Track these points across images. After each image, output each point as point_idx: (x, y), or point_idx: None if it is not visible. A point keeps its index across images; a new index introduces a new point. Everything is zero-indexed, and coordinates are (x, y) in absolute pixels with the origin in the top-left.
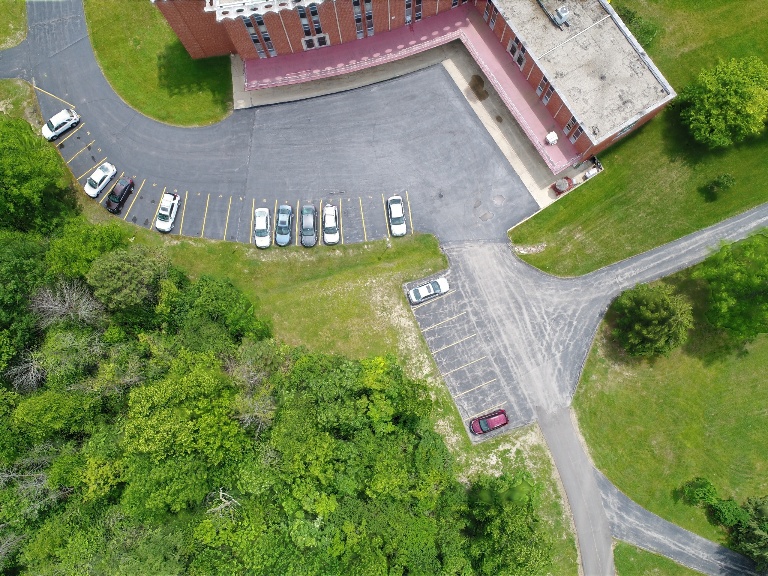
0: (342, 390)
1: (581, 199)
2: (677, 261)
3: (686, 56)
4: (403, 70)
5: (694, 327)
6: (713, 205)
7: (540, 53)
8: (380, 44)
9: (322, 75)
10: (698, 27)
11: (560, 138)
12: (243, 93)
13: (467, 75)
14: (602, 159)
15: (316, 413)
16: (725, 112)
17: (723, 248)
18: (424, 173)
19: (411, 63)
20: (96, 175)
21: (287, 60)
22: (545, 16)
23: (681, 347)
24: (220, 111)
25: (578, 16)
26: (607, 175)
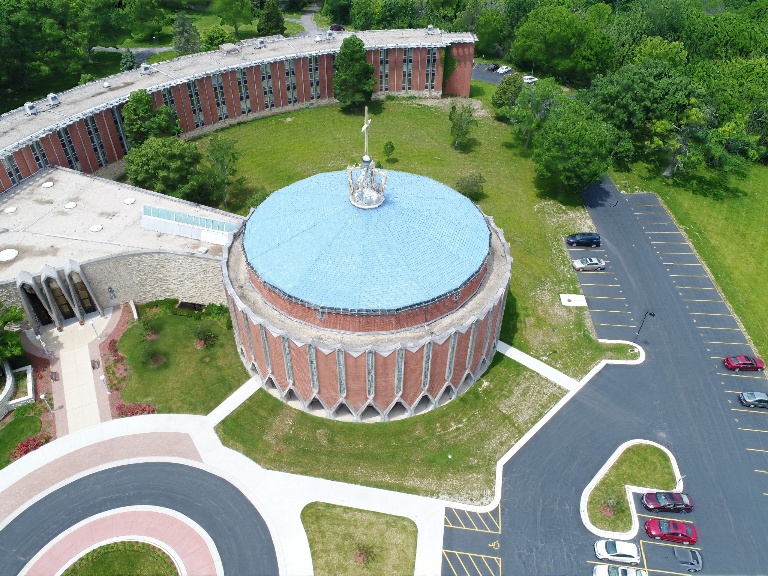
0: (390, 2)
1: None
2: None
3: None
4: None
5: None
6: None
7: None
8: None
9: None
10: None
11: None
12: None
13: None
14: None
15: (399, 2)
16: None
17: None
18: None
19: None
20: (505, 67)
21: None
22: None
23: None
24: None
25: None
26: None
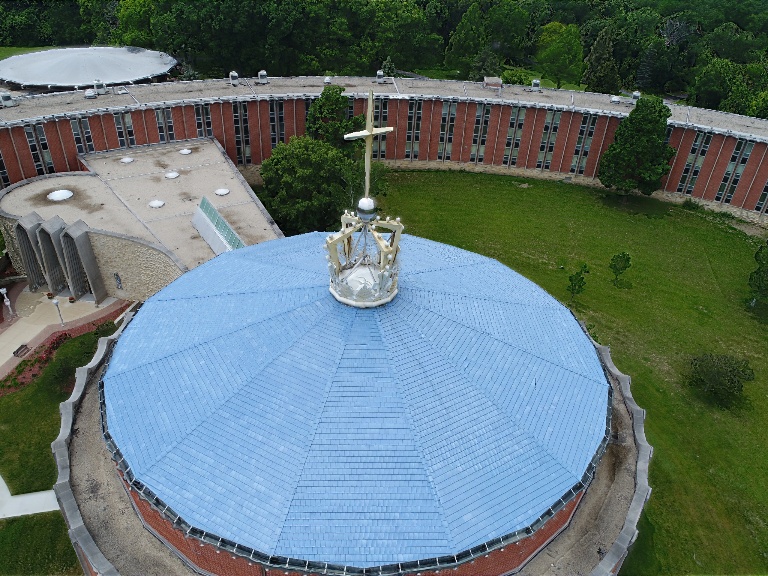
0: None
1: None
2: None
3: None
4: None
5: None
6: None
7: None
8: None
9: None
10: None
11: None
12: None
13: None
14: None
15: None
16: None
17: None
18: None
19: None
20: None
21: None
22: None
23: None
24: None
25: None
26: None
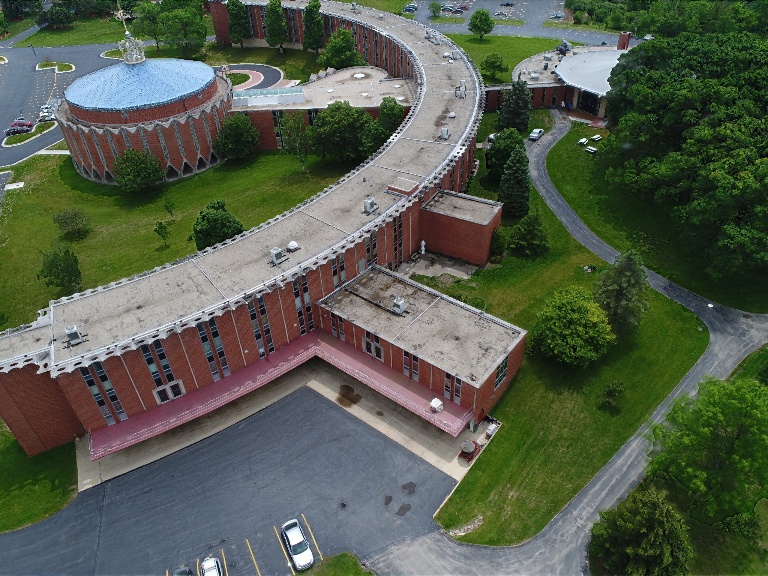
0: None
1: (495, 458)
2: (625, 481)
3: (520, 315)
4: (269, 401)
5: (692, 545)
6: (621, 417)
7: (393, 336)
8: (239, 380)
9: (180, 421)
10: (517, 296)
11: (445, 403)
12: (90, 472)
13: (334, 387)
14: (495, 415)
15: None
16: (575, 331)
17: (654, 430)
18: (317, 488)
19: (276, 393)
20: None
21: (140, 419)
22: (385, 312)
23: (696, 575)
24: (60, 499)
25: (414, 305)
26: (508, 427)
